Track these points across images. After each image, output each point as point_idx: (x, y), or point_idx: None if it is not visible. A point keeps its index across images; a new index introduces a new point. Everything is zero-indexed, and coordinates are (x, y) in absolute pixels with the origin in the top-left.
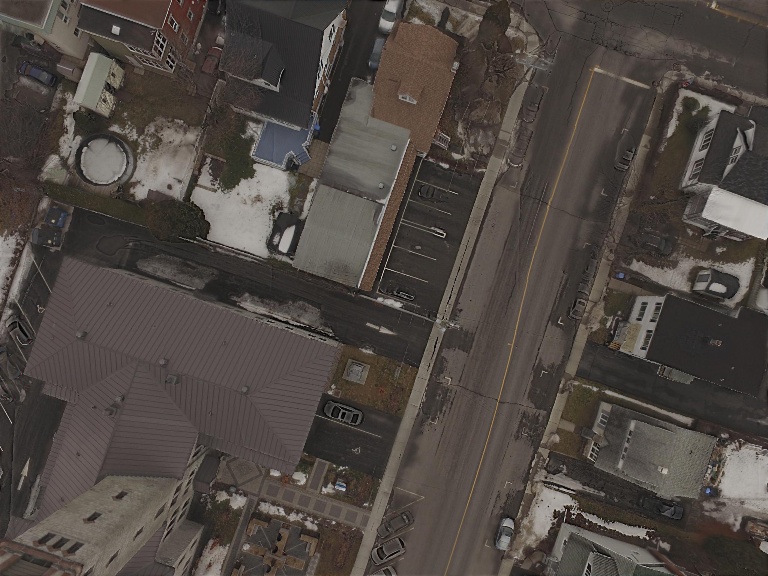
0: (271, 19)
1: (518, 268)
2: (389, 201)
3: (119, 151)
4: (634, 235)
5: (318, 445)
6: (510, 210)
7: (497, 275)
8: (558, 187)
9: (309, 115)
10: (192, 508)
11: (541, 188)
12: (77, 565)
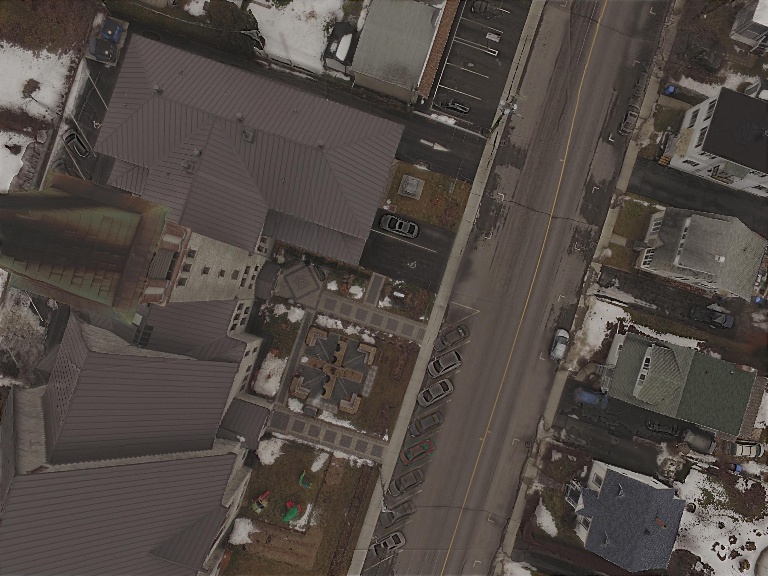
0: None
1: (569, 85)
2: (446, 4)
3: None
4: (682, 52)
5: (374, 259)
6: (561, 29)
7: (548, 93)
8: (608, 5)
9: None
10: (250, 321)
11: (591, 6)
12: None
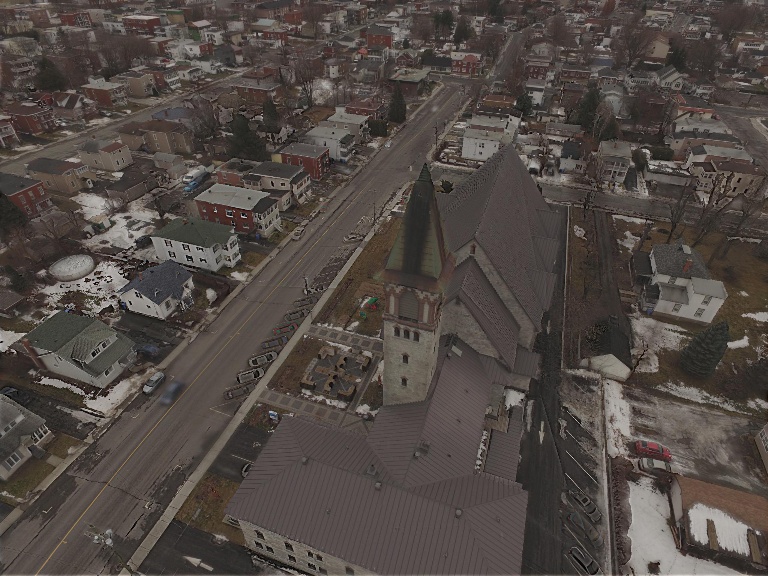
0: None
1: None
2: None
3: None
4: None
5: None
6: None
7: None
8: None
9: None
10: None
11: None
12: (385, 318)
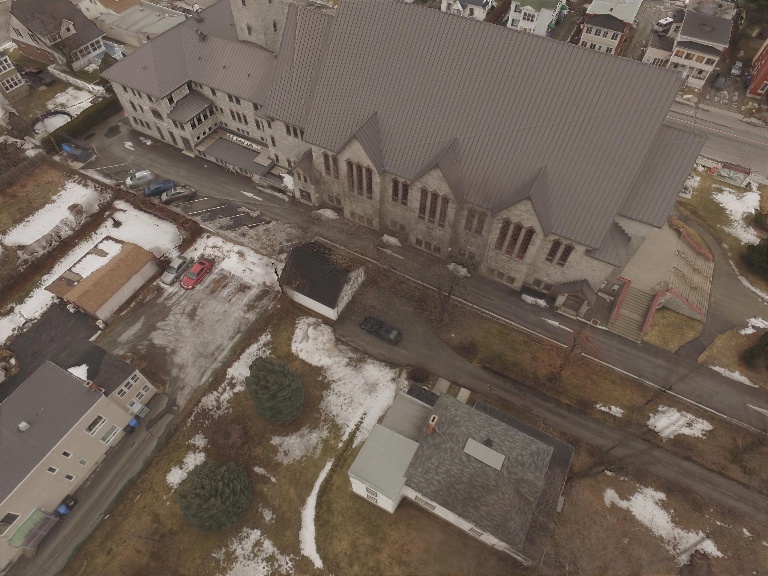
0: (35, 4)
1: None
2: None
3: (53, 117)
4: None
5: None
6: (205, 2)
7: None
8: None
9: (99, 29)
10: None
11: None
12: None
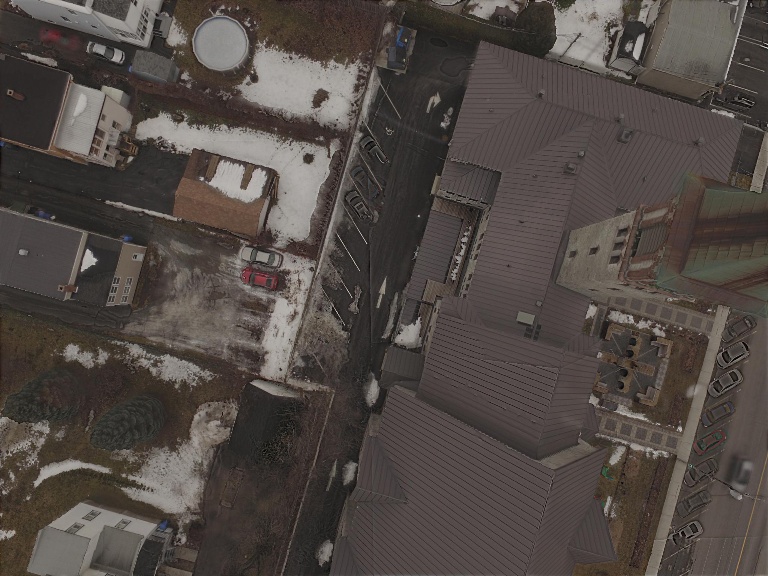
0: None
1: None
2: None
3: None
4: None
5: None
6: None
7: None
8: None
9: None
10: None
11: None
12: None
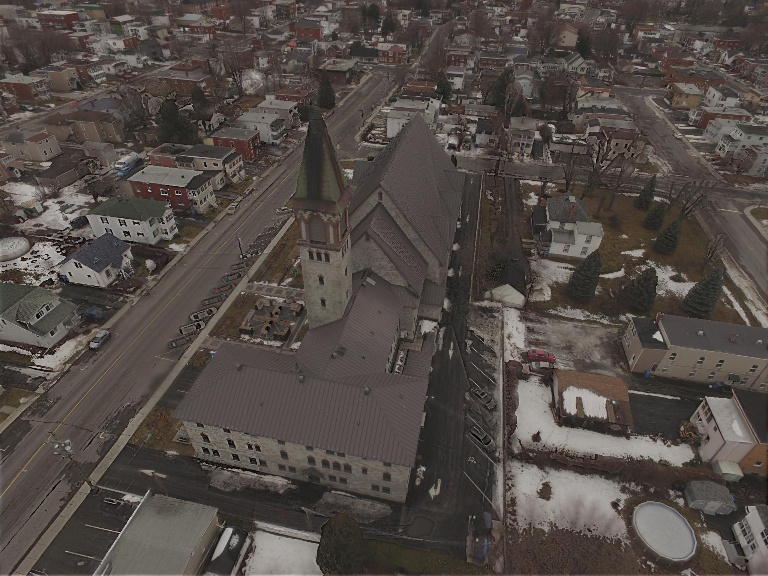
0: None
1: None
2: None
3: None
4: None
5: None
6: None
7: (1, 541)
8: None
9: None
10: None
11: None
12: (299, 244)
